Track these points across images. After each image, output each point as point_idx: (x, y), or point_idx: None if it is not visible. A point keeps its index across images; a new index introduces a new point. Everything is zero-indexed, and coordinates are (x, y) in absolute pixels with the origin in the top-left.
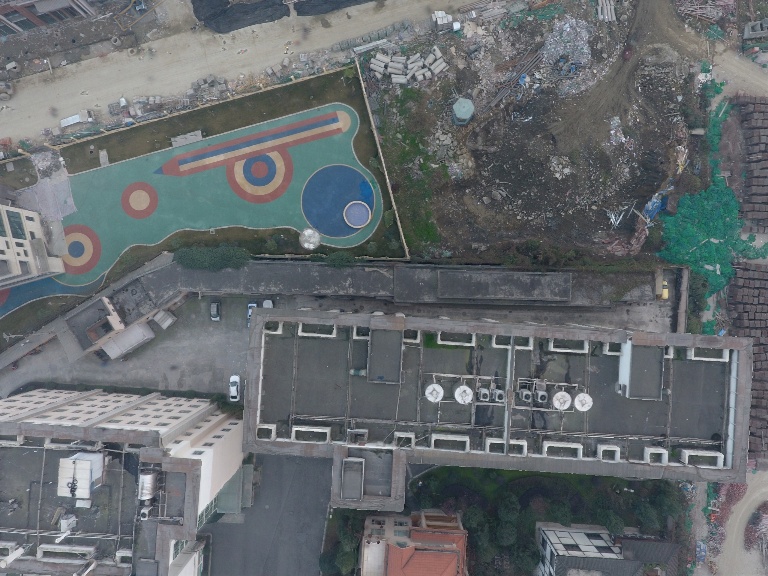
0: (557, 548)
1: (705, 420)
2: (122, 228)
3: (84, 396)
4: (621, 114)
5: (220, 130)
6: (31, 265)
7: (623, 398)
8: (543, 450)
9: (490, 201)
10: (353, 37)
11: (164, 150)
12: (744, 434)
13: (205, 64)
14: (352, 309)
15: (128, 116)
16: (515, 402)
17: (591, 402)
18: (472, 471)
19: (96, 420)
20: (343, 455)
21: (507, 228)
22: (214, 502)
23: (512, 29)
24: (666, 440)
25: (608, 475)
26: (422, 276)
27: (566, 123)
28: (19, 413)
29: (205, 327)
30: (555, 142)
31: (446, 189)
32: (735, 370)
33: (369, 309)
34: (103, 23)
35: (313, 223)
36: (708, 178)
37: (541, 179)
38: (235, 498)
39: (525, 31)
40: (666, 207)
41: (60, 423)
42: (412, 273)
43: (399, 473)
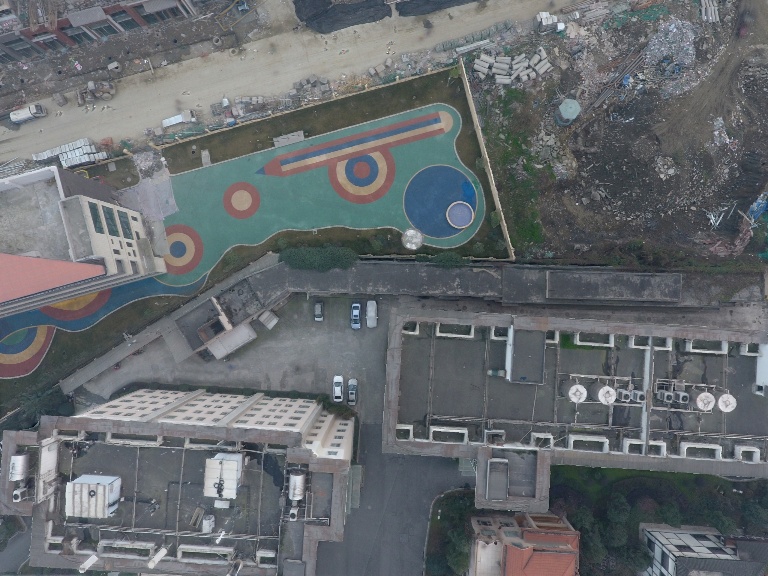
0: (671, 549)
1: None
2: (224, 228)
3: (194, 396)
4: (724, 115)
5: (322, 130)
6: (139, 265)
7: (760, 399)
8: (681, 451)
9: (589, 202)
10: (455, 37)
11: (266, 150)
12: None
13: (307, 64)
14: (455, 309)
15: (230, 116)
16: (652, 403)
17: (735, 403)
18: (575, 472)
19: (227, 420)
20: (487, 456)
21: (606, 229)
22: None
23: (615, 30)
24: None
25: None
26: (530, 277)
27: (669, 124)
28: (145, 413)
29: (307, 327)
30: (659, 143)
31: (549, 190)
32: None
33: (472, 310)
34: (204, 23)
35: (415, 223)
36: None
37: (645, 180)
38: None
39: (628, 32)
40: None
41: (194, 423)
42: (520, 274)
43: (544, 474)
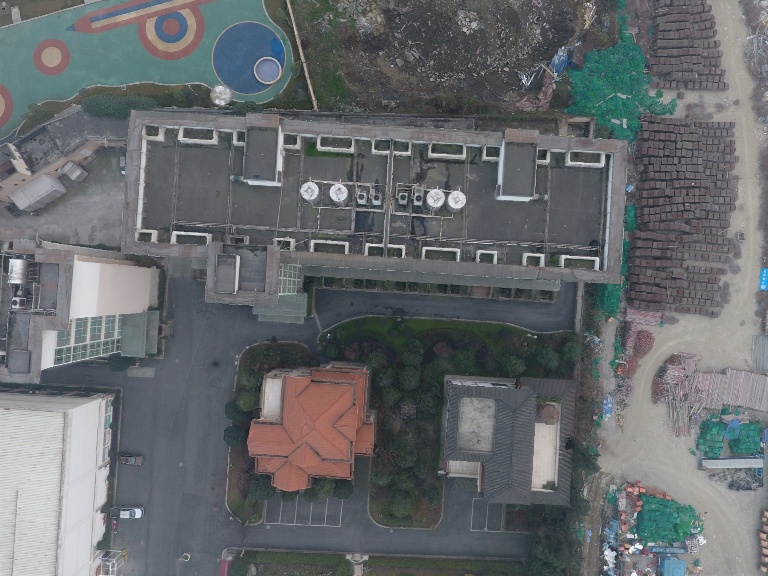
0: None
1: (583, 227)
2: (34, 84)
3: None
4: None
5: None
6: None
7: (502, 205)
8: (422, 255)
9: (403, 63)
10: None
11: (76, 7)
12: (618, 235)
13: None
14: None
15: None
16: (395, 209)
17: (464, 199)
18: None
19: None
20: (217, 250)
21: (420, 90)
22: (116, 343)
23: None
24: (544, 245)
25: (483, 275)
26: None
27: None
28: None
29: (116, 182)
30: None
31: (355, 45)
32: (611, 174)
33: None
34: None
35: (224, 80)
36: (616, 35)
37: (449, 34)
38: (139, 342)
39: None
40: (571, 59)
41: None
42: None
43: (273, 268)
